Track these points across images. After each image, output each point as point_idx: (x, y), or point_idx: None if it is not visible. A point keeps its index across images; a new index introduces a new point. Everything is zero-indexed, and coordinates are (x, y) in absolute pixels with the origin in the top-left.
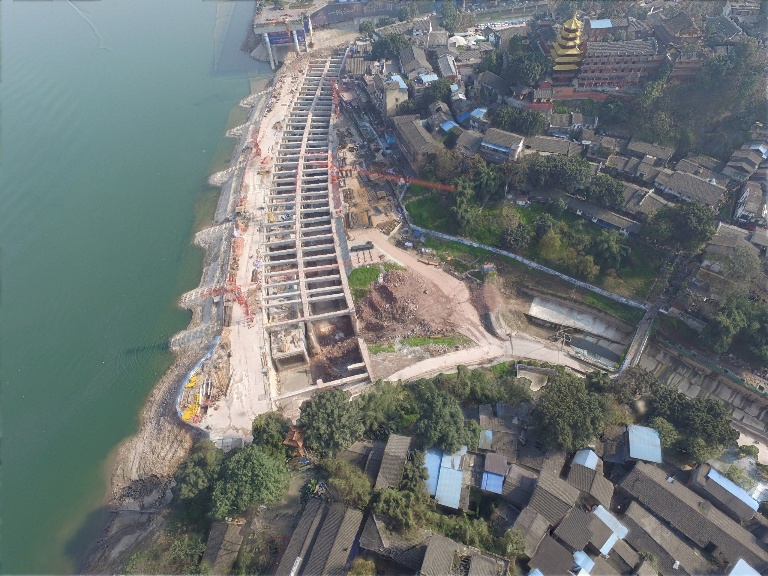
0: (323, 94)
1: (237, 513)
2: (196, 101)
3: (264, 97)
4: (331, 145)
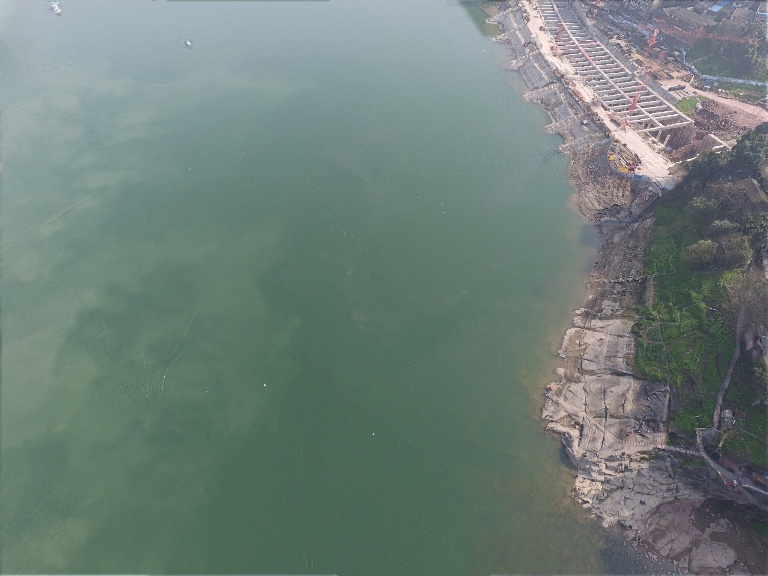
0: (559, 10)
1: (764, 165)
2: (448, 22)
3: (511, 14)
4: (596, 38)
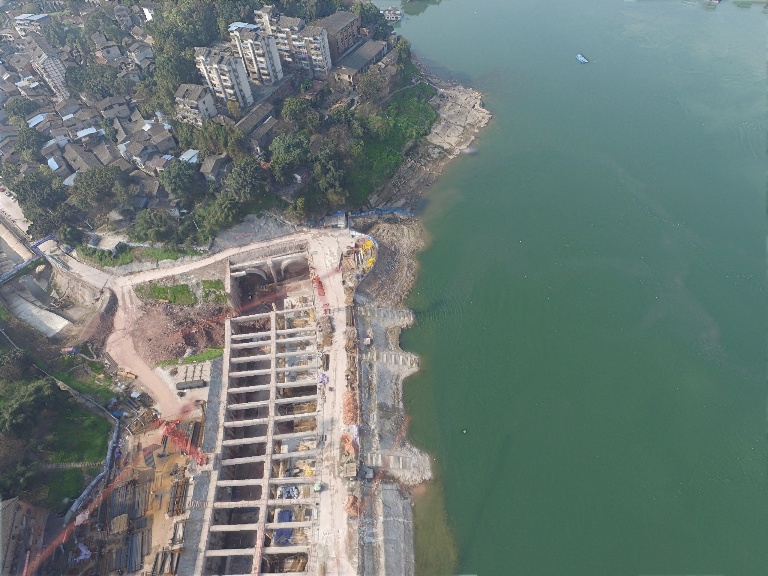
0: None
1: None
2: None
3: None
4: None
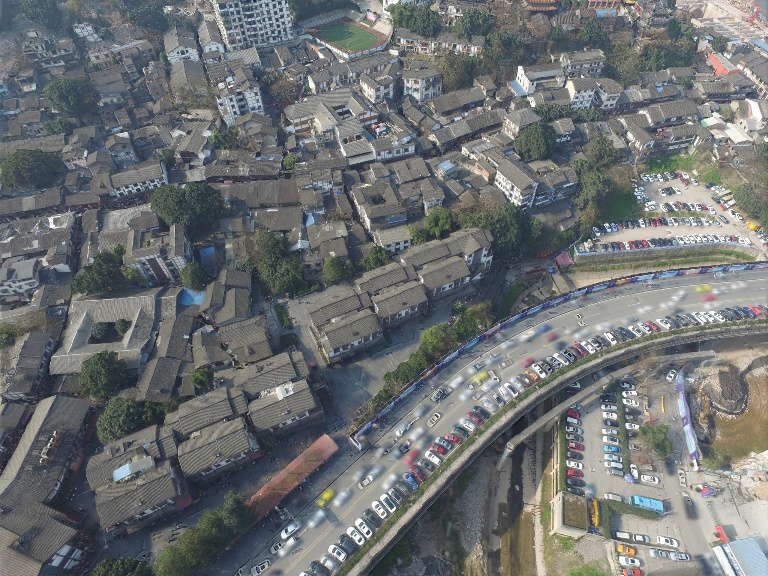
0: None
1: None
2: None
3: None
4: None
